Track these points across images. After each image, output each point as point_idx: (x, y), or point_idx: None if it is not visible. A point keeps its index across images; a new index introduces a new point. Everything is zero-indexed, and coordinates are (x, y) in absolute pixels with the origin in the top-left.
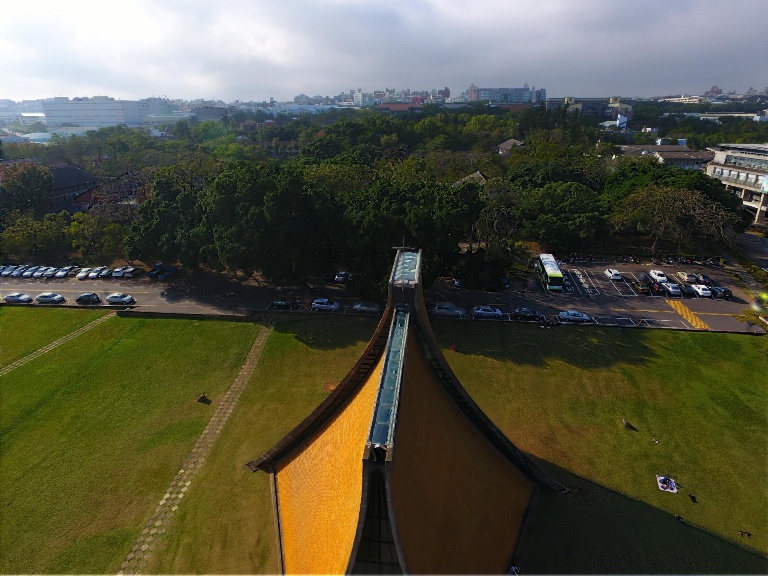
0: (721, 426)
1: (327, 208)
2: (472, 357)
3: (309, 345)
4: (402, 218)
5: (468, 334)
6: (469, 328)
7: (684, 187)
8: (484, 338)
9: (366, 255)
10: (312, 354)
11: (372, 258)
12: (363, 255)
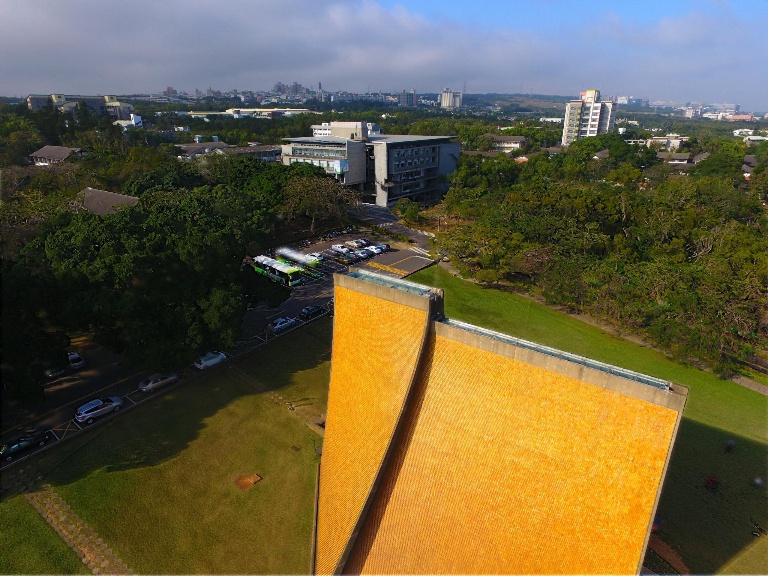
0: (482, 324)
1: (22, 272)
2: (321, 367)
3: (147, 464)
4: (170, 254)
5: (292, 351)
6: (286, 345)
7: (314, 176)
8: (308, 347)
9: (137, 316)
10: (167, 470)
11: (150, 316)
12: (132, 317)
